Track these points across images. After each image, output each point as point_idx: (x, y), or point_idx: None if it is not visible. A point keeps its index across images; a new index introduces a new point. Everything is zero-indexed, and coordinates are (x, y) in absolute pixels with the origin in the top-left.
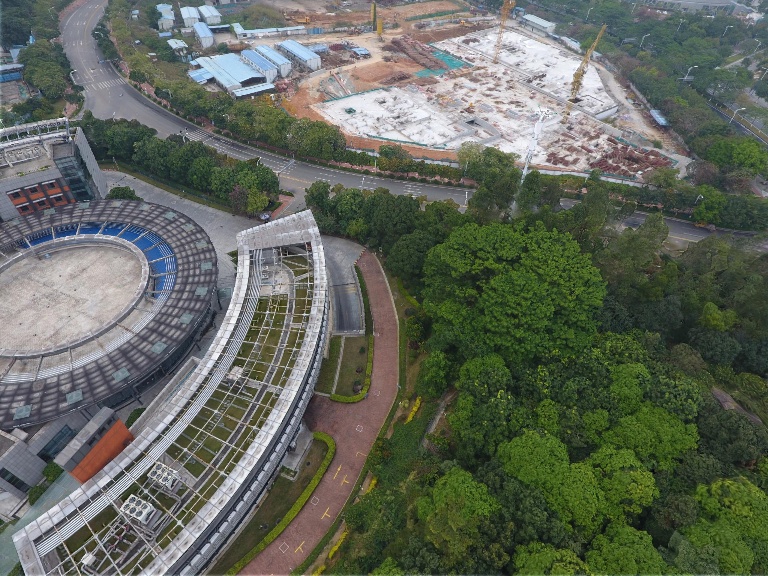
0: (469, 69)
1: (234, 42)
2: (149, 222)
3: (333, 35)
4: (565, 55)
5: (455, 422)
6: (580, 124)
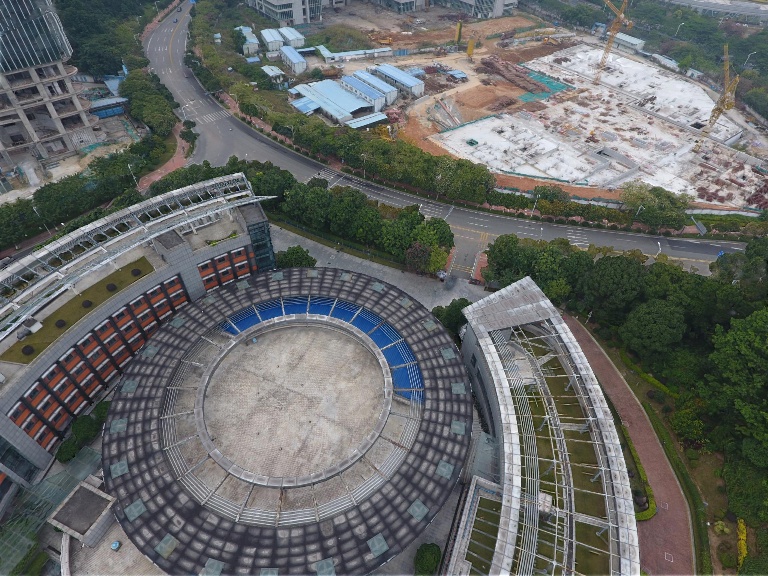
0: (573, 92)
1: (324, 66)
2: (358, 296)
3: (420, 56)
4: (665, 74)
5: None
6: (715, 153)
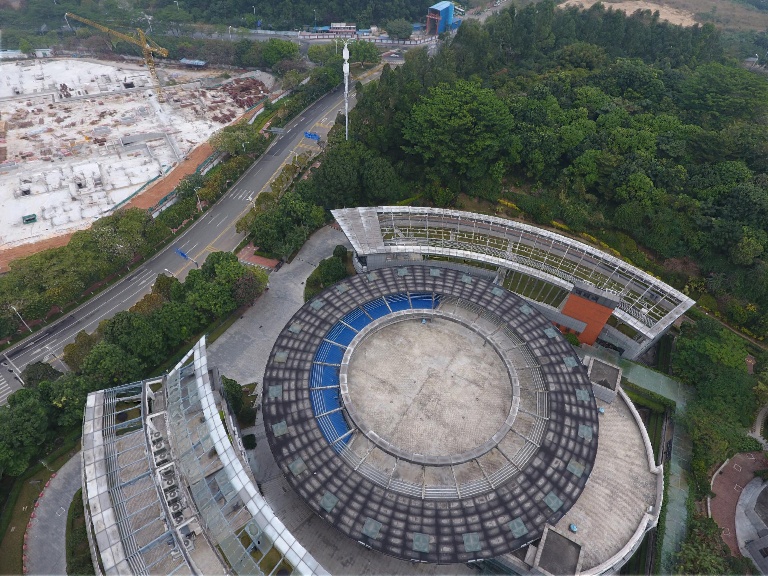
0: None
1: None
2: (325, 321)
3: None
4: (27, 64)
5: (542, 165)
6: (175, 94)
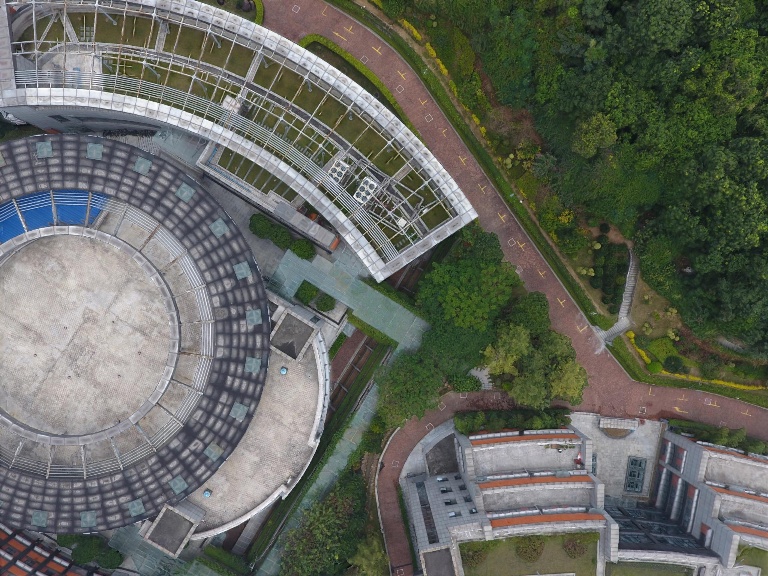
0: None
1: None
2: None
3: None
4: None
5: None
6: None
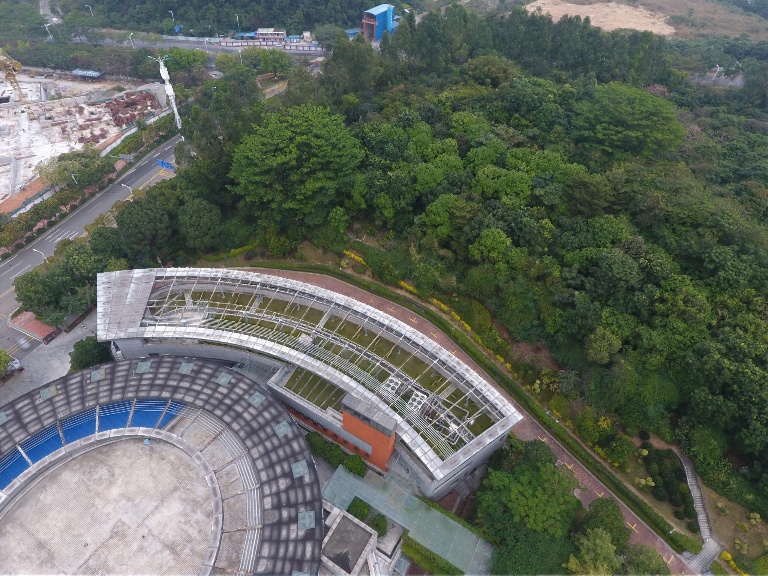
0: None
1: None
2: None
3: None
4: None
5: (390, 212)
6: (49, 111)
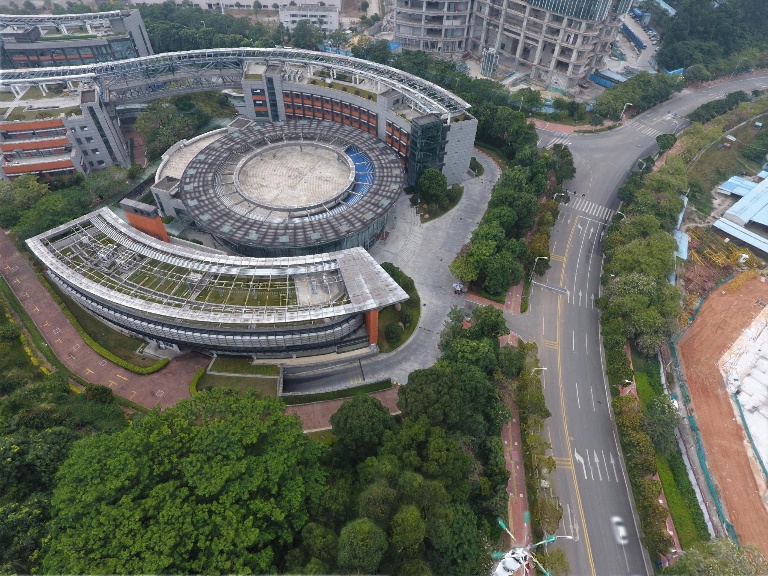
0: None
1: None
2: (375, 193)
3: None
4: None
5: None
6: None
